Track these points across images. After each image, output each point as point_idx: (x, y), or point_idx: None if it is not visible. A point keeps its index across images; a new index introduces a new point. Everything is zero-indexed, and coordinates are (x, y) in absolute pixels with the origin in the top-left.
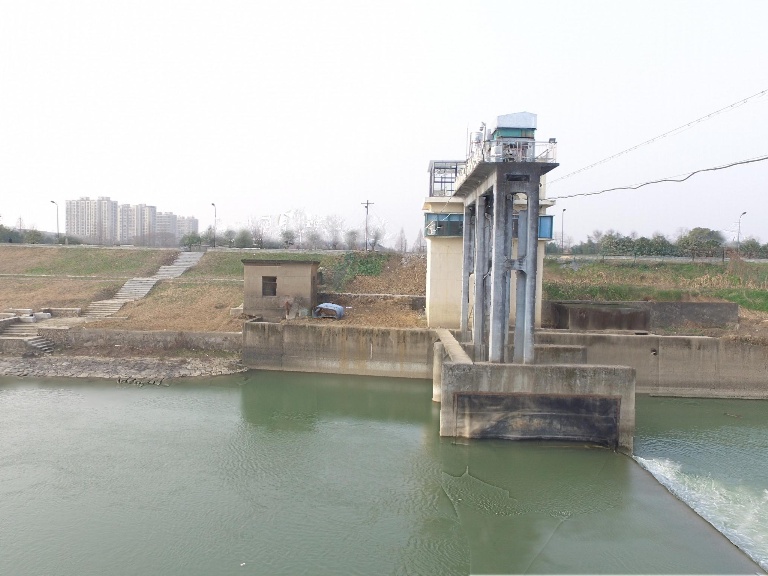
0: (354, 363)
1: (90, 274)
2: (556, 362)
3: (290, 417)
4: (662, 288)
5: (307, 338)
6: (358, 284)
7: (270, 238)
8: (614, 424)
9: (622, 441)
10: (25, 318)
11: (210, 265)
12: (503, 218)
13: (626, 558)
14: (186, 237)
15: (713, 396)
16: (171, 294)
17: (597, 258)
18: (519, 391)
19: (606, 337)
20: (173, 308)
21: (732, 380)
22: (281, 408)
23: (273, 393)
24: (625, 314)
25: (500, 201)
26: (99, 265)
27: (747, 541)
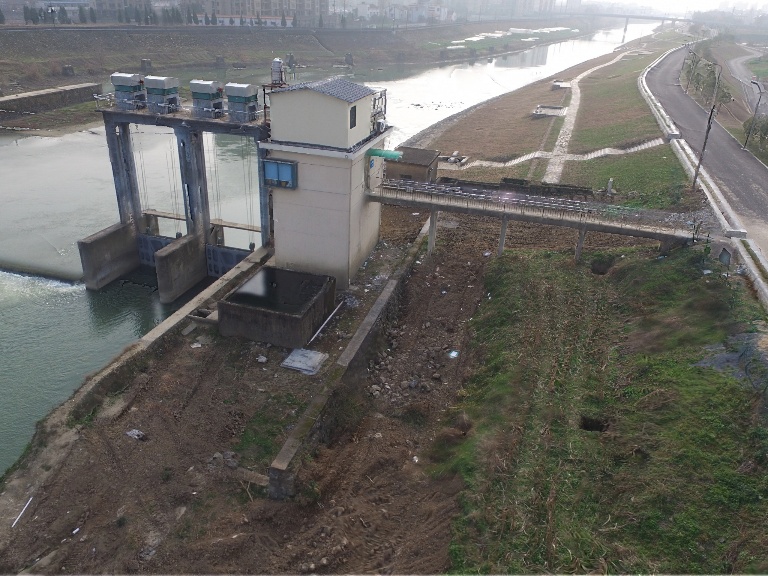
0: None
1: None
2: None
3: None
4: (487, 440)
5: None
6: None
7: None
8: None
9: None
10: None
11: (620, 157)
12: None
13: (25, 250)
14: None
15: None
16: (493, 168)
17: None
18: None
19: None
20: None
21: None
22: None
23: None
24: None
25: None
26: None
27: (0, 276)
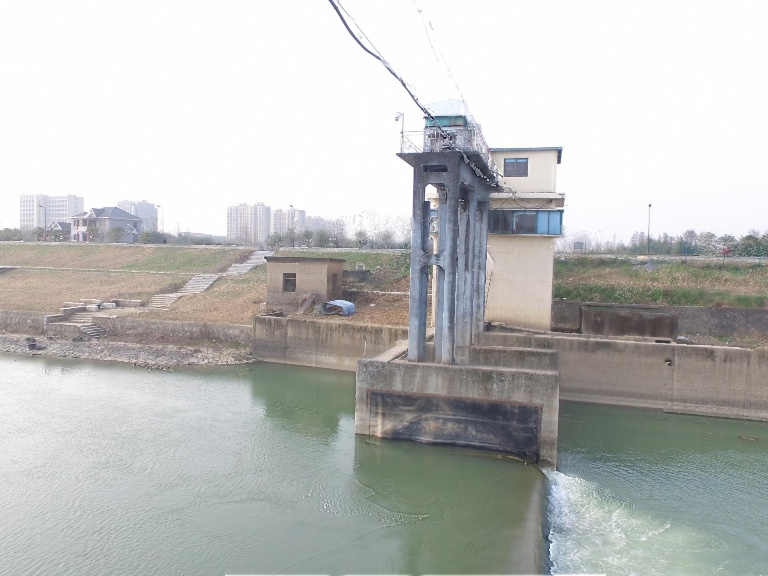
0: (349, 359)
1: (171, 270)
2: (520, 366)
3: (292, 409)
4: (741, 293)
5: (308, 333)
6: (404, 283)
7: (346, 238)
8: (534, 435)
9: (544, 454)
10: (89, 307)
11: None
12: (420, 211)
13: (405, 570)
14: (269, 237)
15: (742, 417)
16: (223, 289)
17: (681, 258)
18: (433, 392)
19: (611, 343)
20: (215, 302)
21: (767, 400)
22: (285, 400)
23: (278, 385)
24: (648, 319)
25: (417, 193)
26: (182, 262)
27: (578, 573)
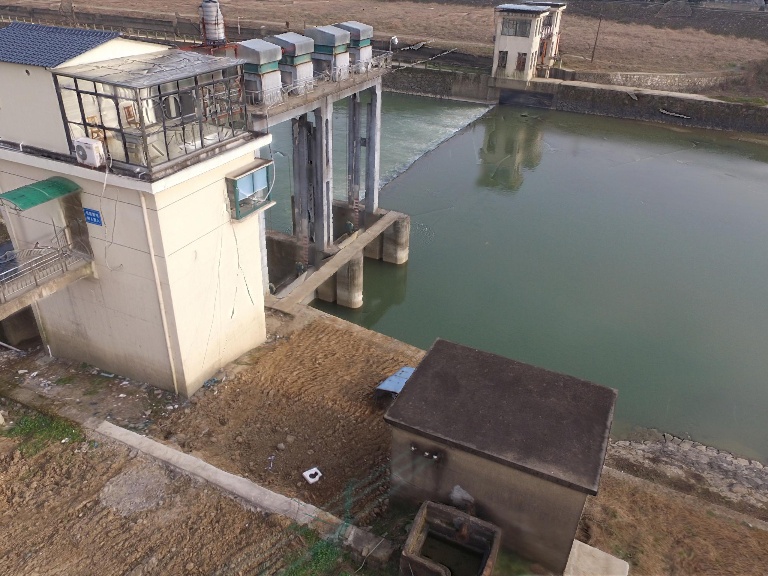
0: None
1: None
2: None
3: None
4: None
5: None
6: None
7: None
8: None
9: None
10: None
11: None
12: None
13: None
14: None
15: None
16: None
17: None
18: None
19: None
20: None
21: None
22: None
23: None
24: None
25: None
26: None
27: None
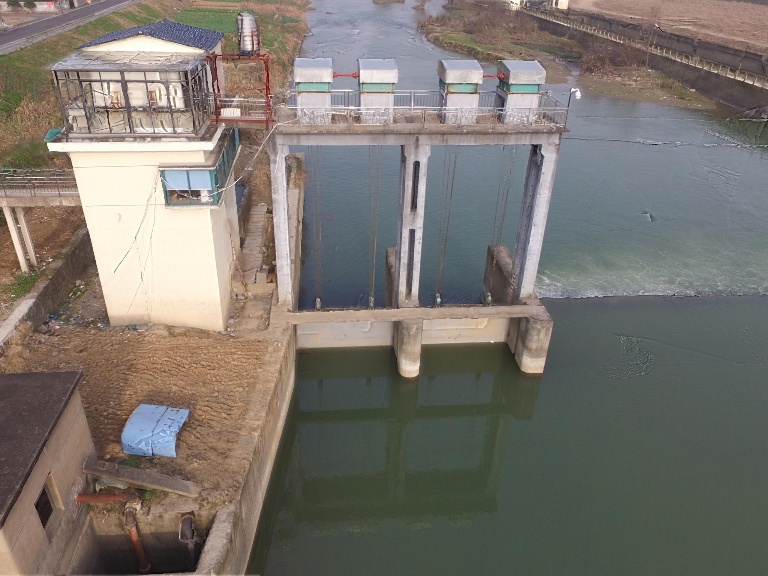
0: None
1: None
2: None
3: None
4: None
5: None
6: None
7: None
8: None
9: None
10: None
11: None
12: None
13: None
14: None
15: None
16: None
17: None
18: None
19: None
20: None
21: None
22: None
23: None
24: None
25: None
26: None
27: None
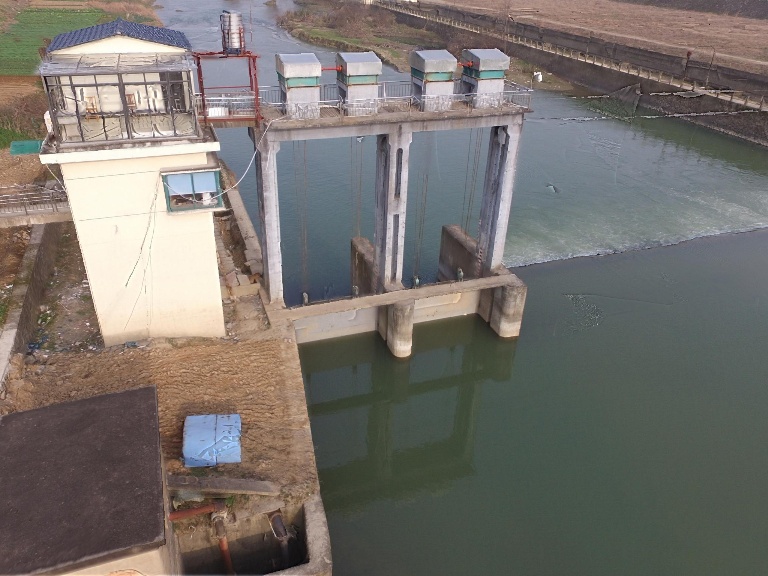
0: None
1: None
2: None
3: None
4: None
5: None
6: None
7: None
8: None
9: None
10: None
11: None
12: None
13: None
14: None
15: None
16: None
17: None
18: None
19: None
20: None
21: None
22: None
23: None
24: None
25: None
26: None
27: None
